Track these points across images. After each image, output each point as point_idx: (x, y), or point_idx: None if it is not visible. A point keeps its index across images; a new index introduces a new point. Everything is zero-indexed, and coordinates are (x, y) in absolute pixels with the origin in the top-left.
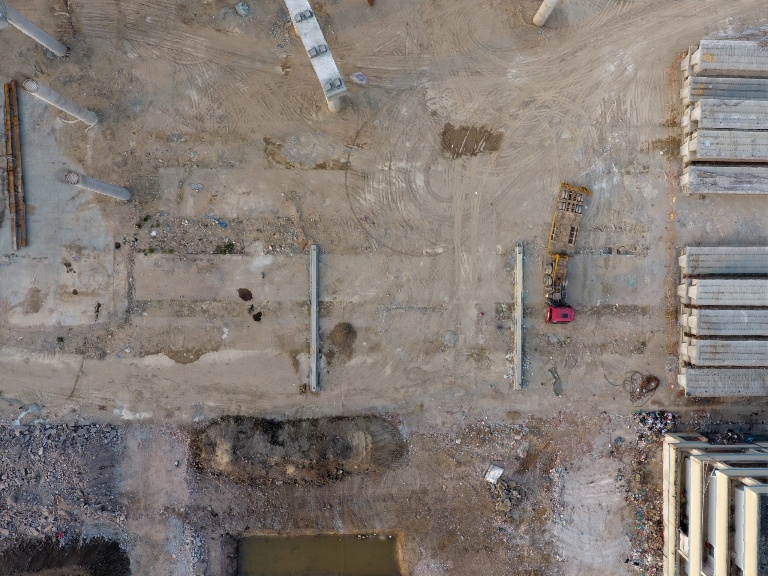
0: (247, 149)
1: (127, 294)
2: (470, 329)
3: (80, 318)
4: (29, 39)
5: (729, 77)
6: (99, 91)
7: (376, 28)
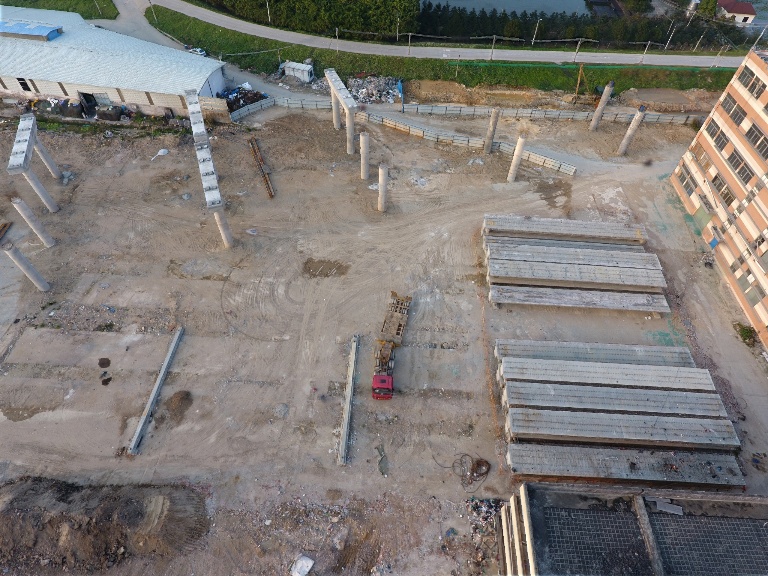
0: (155, 265)
1: (0, 357)
2: (302, 403)
3: None
4: (38, 204)
5: (512, 237)
6: (66, 230)
7: (272, 208)
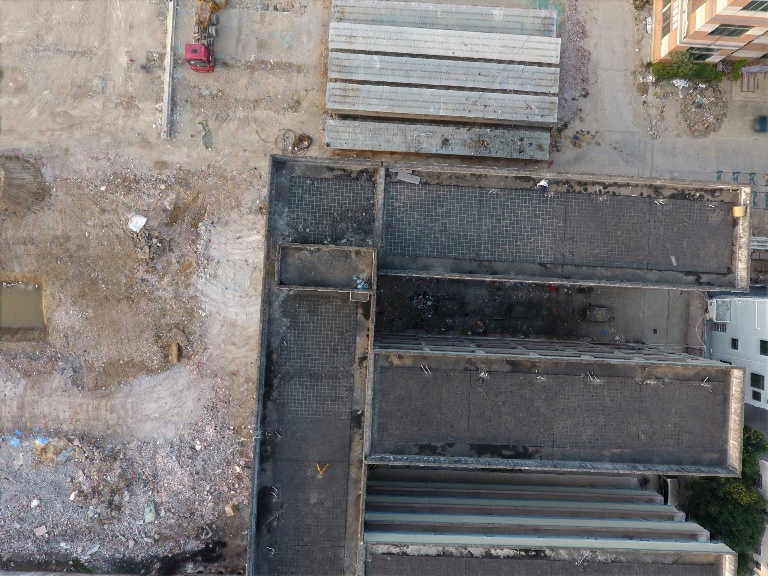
0: None
1: None
2: (119, 75)
3: None
4: None
5: None
6: None
7: None
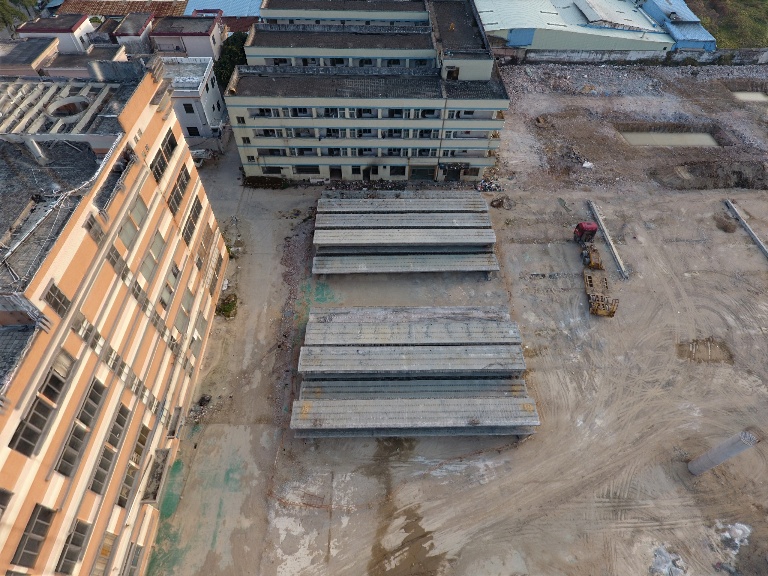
0: None
1: None
2: (639, 230)
3: None
4: None
5: None
6: None
7: None
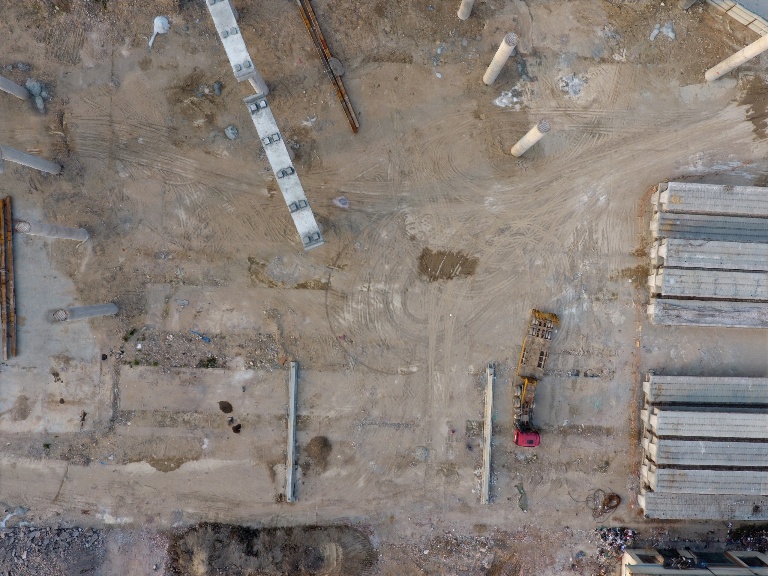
0: (232, 268)
1: (112, 404)
2: (441, 445)
3: (66, 426)
4: None
5: (696, 214)
6: (91, 209)
7: (360, 154)
